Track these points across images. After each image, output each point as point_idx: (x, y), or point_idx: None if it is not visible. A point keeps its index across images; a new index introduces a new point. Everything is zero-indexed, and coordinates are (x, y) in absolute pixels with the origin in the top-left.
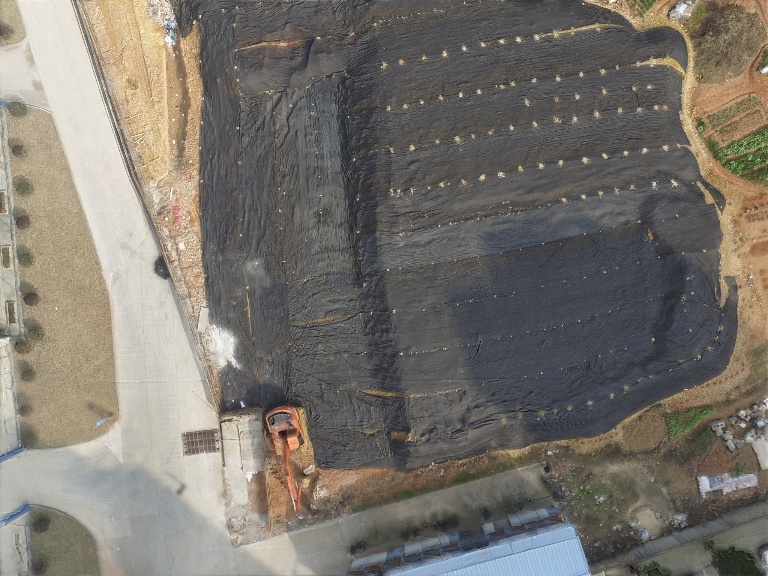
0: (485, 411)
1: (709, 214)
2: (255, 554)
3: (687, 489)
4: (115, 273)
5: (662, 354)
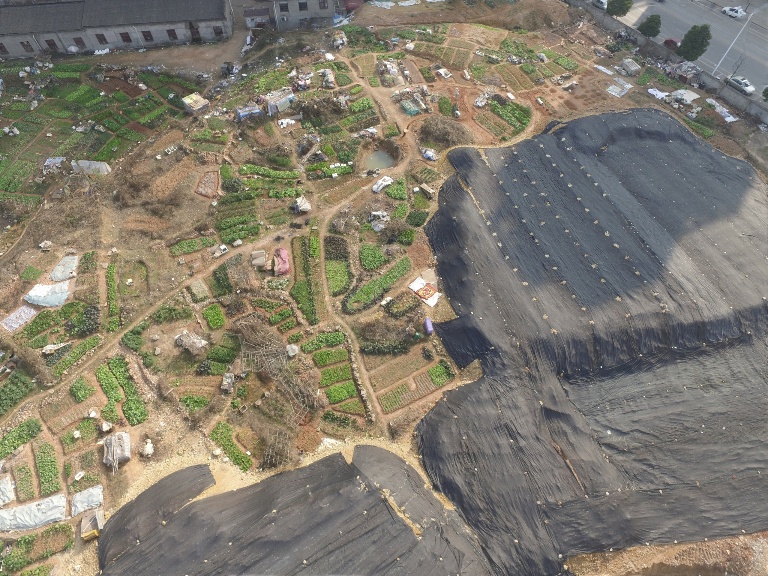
0: None
1: (576, 122)
2: None
3: (740, 126)
4: None
5: (678, 135)
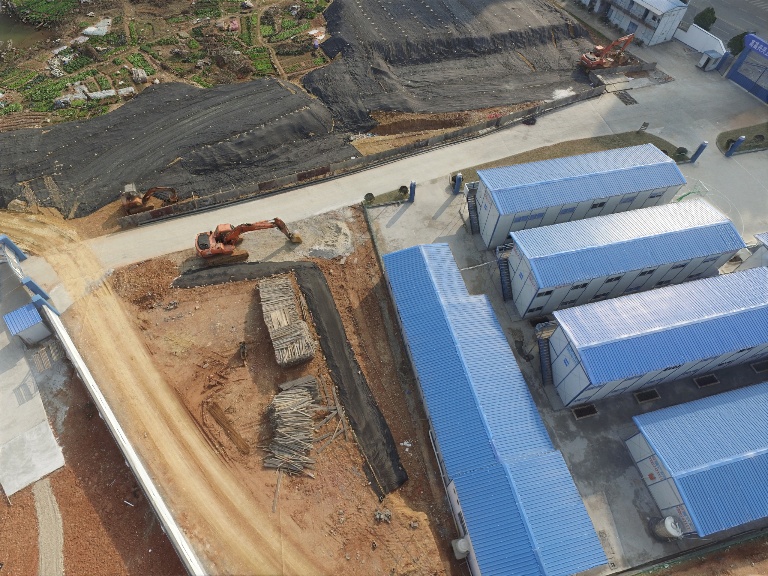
0: (542, 5)
1: None
2: (672, 73)
3: None
4: (545, 142)
5: None
